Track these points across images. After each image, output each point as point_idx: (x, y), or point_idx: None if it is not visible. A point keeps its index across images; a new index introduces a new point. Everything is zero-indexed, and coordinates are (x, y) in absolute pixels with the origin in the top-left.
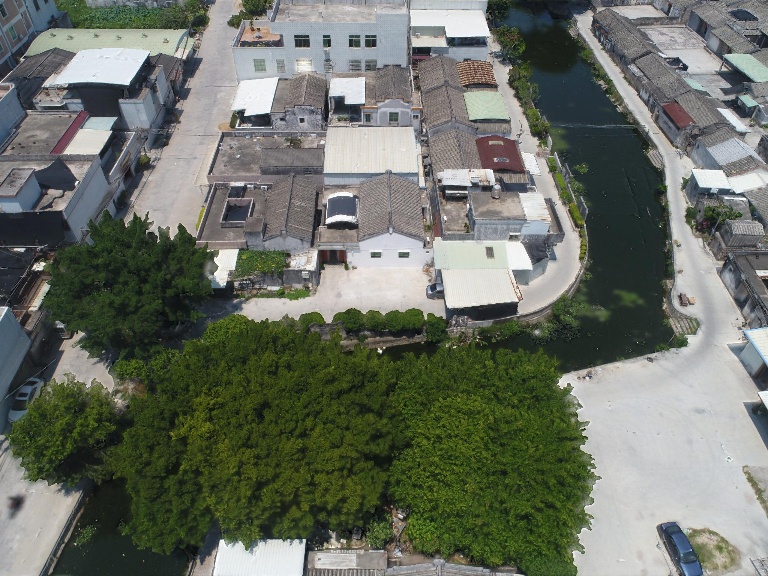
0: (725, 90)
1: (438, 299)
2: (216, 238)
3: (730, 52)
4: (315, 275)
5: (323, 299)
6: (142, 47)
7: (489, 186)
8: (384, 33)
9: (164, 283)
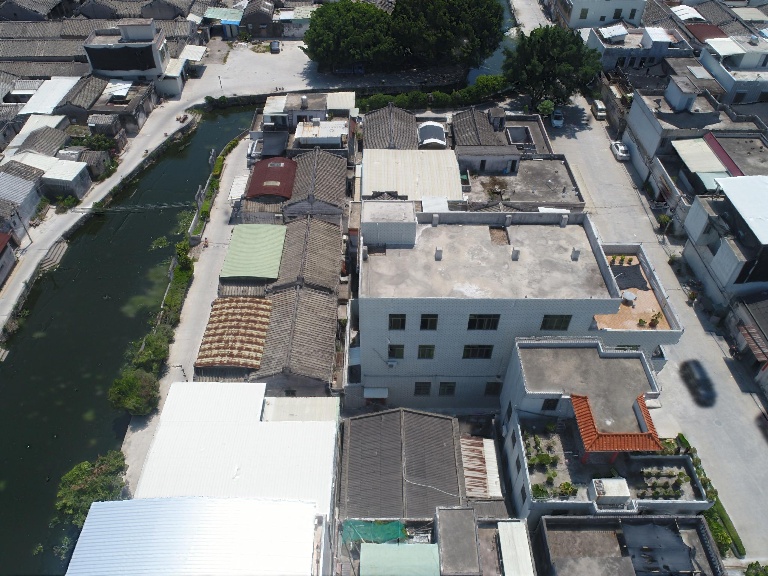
0: None
1: None
2: None
3: None
4: None
5: None
6: None
7: None
8: None
9: None
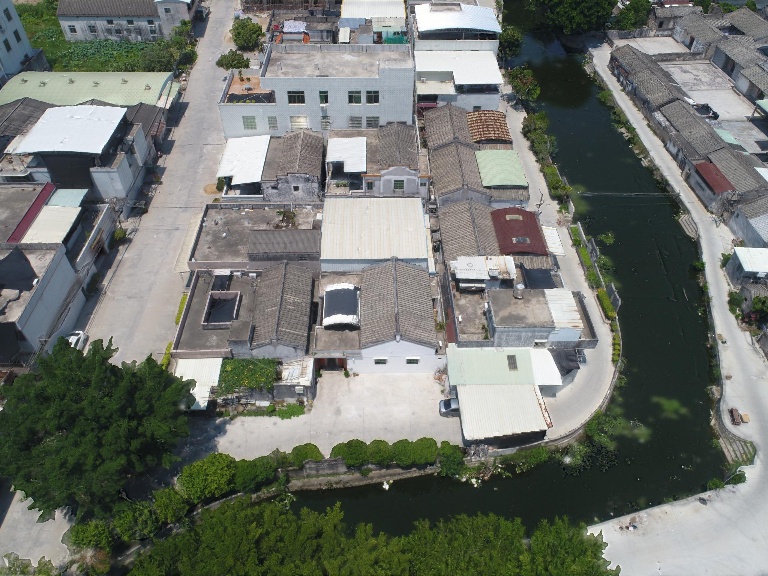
0: (761, 144)
1: (453, 417)
2: (196, 344)
3: (760, 94)
4: (310, 390)
5: (320, 417)
6: (121, 95)
7: (509, 279)
8: (387, 89)
9: (128, 435)
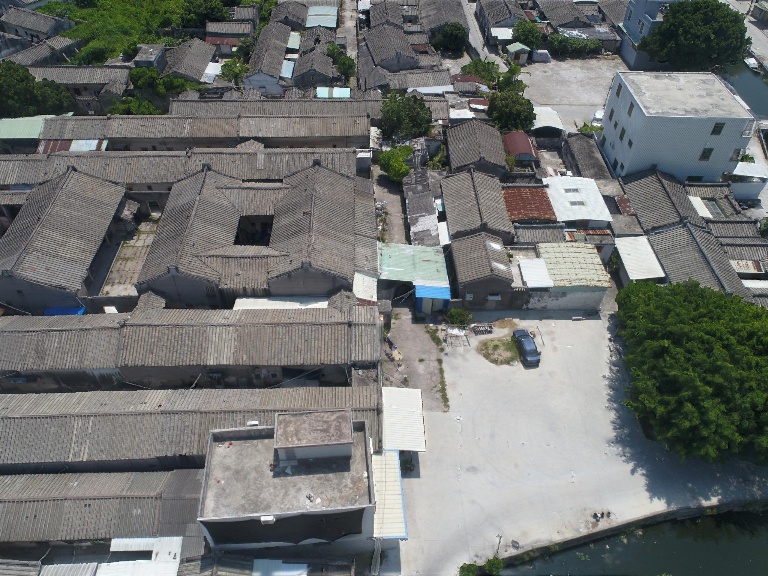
0: None
1: None
2: None
3: None
4: None
5: None
6: None
7: None
8: None
9: None
